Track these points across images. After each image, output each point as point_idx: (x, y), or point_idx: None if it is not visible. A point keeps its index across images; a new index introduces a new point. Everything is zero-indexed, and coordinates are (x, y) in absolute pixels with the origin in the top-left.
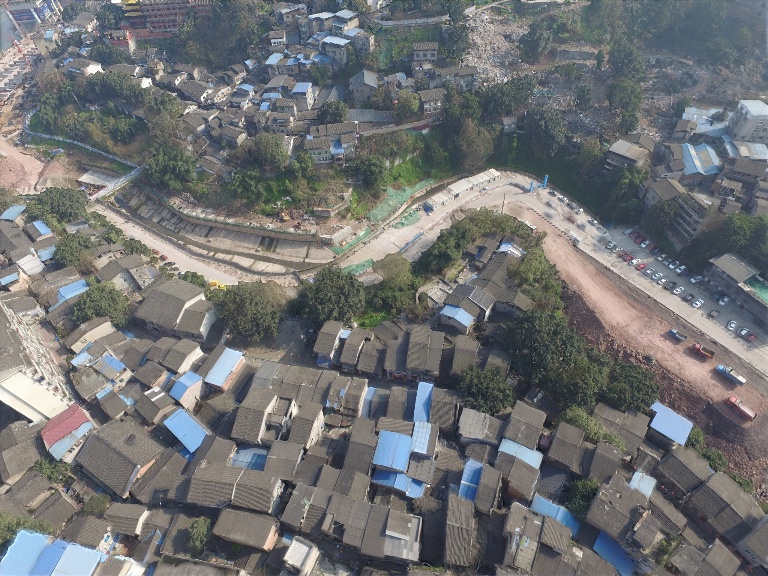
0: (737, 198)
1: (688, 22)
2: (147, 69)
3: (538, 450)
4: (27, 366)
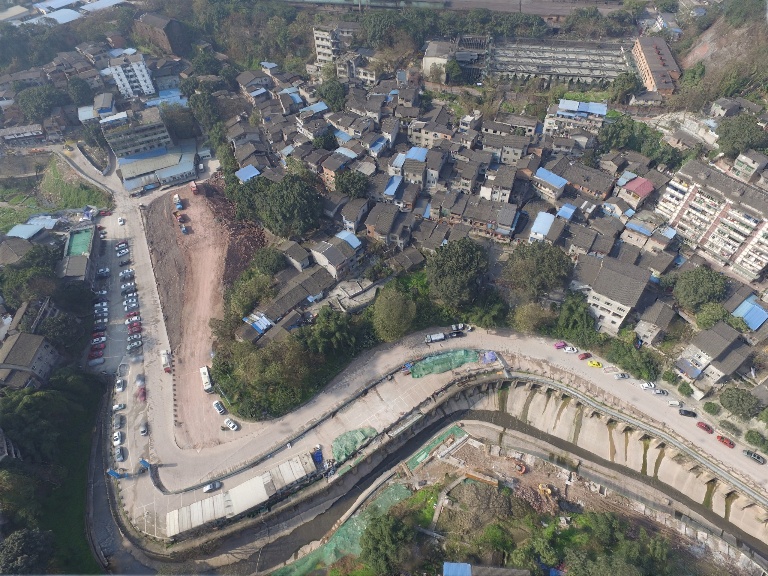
0: None
1: None
2: None
3: None
4: (679, 174)
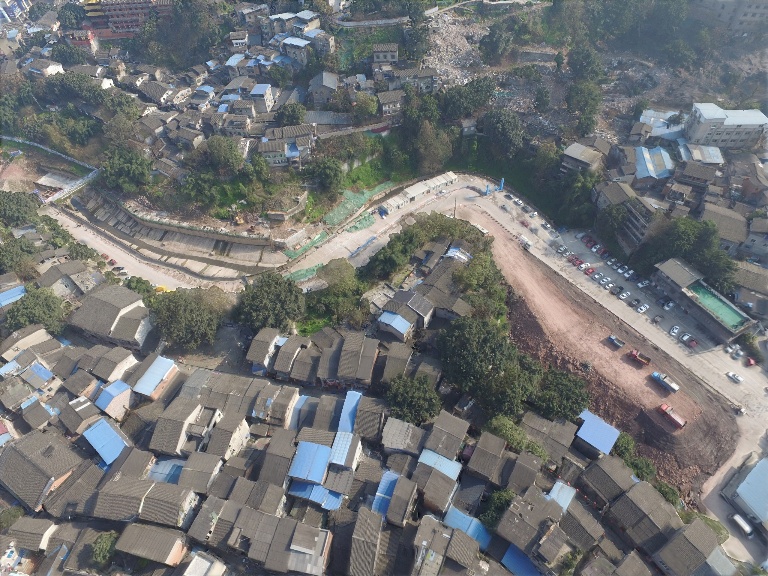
0: (686, 202)
1: (650, 24)
2: (108, 70)
3: (458, 461)
4: None
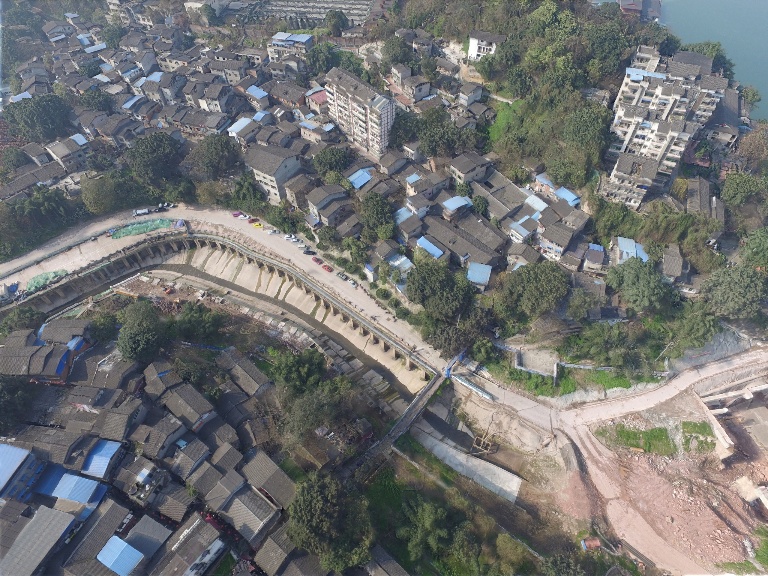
0: None
1: None
2: None
3: None
4: (327, 79)
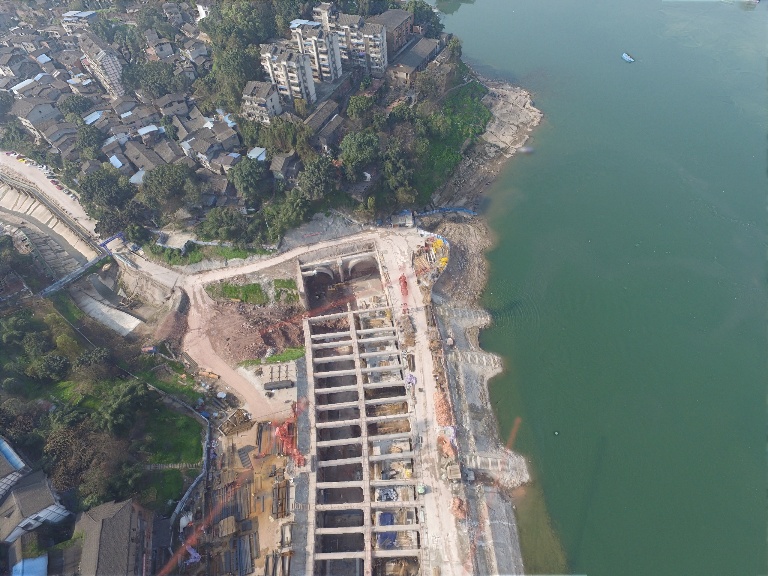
0: None
1: None
2: None
3: None
4: None
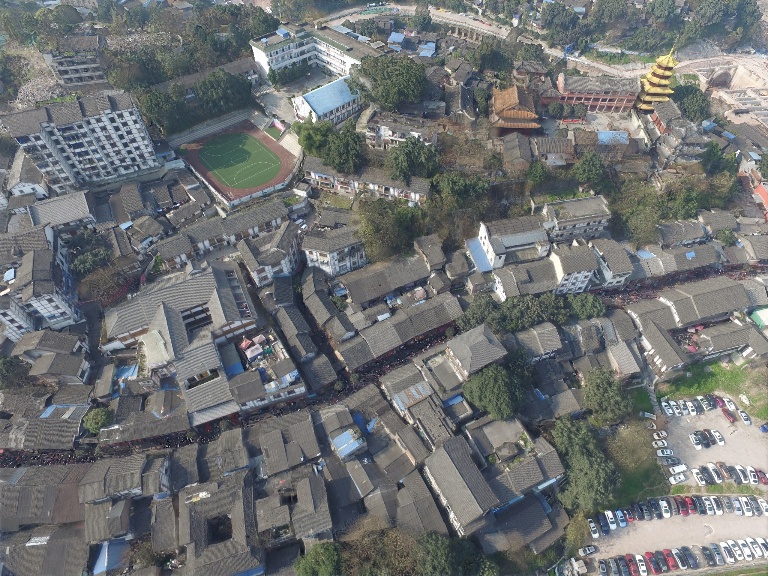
0: None
1: None
2: None
3: None
4: None
